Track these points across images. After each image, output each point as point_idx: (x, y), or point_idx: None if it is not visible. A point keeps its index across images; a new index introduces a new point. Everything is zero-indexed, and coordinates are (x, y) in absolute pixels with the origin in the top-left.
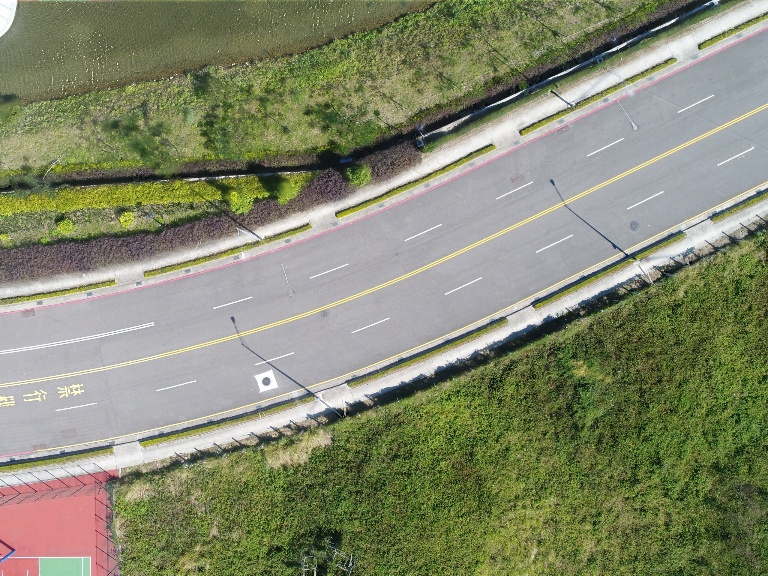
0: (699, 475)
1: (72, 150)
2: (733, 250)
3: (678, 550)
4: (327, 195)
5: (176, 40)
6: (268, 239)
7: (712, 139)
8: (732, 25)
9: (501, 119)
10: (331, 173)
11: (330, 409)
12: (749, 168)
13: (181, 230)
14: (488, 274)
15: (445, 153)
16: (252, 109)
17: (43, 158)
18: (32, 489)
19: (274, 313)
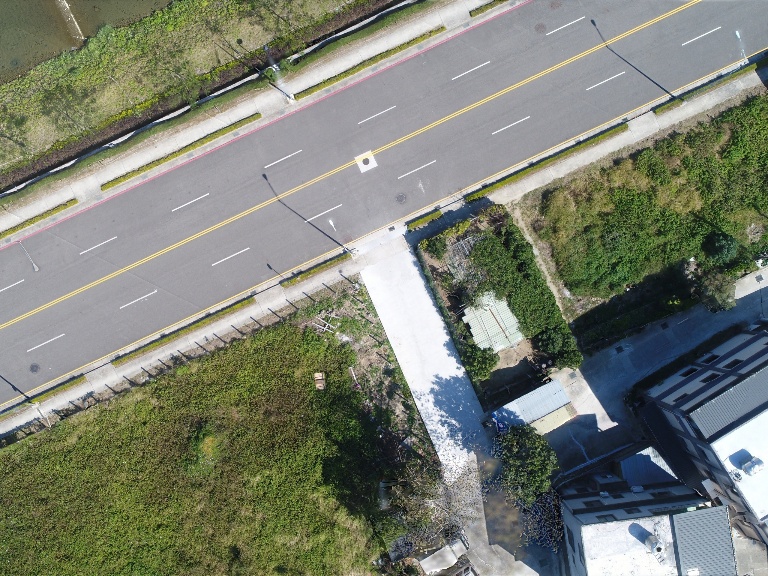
0: None
1: None
2: (125, 397)
3: None
4: None
5: None
6: None
7: (114, 281)
8: (136, 166)
9: None
10: None
11: None
12: (152, 311)
13: None
14: None
15: None
16: None
17: None
18: None
19: None
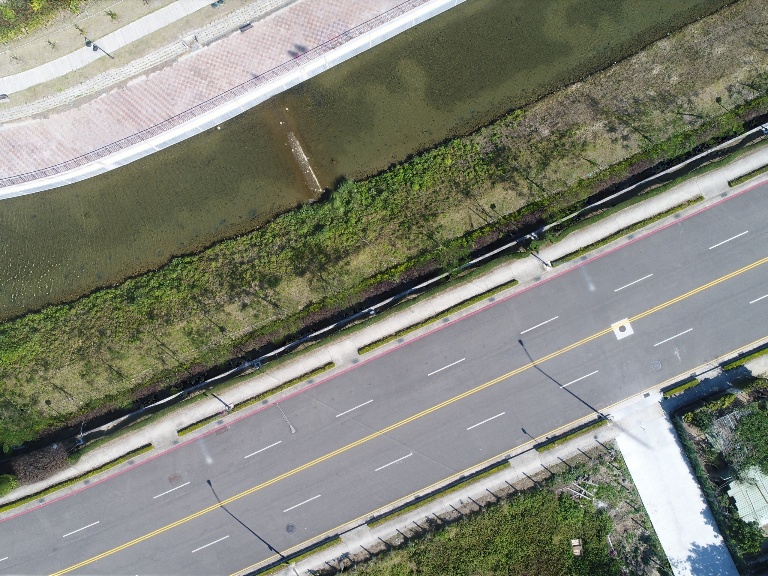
0: None
1: None
2: (384, 560)
3: None
4: None
5: None
6: None
7: (370, 444)
8: (393, 330)
9: (160, 419)
10: None
11: None
12: (407, 474)
13: None
14: (144, 572)
15: (104, 451)
16: None
17: None
18: None
19: None
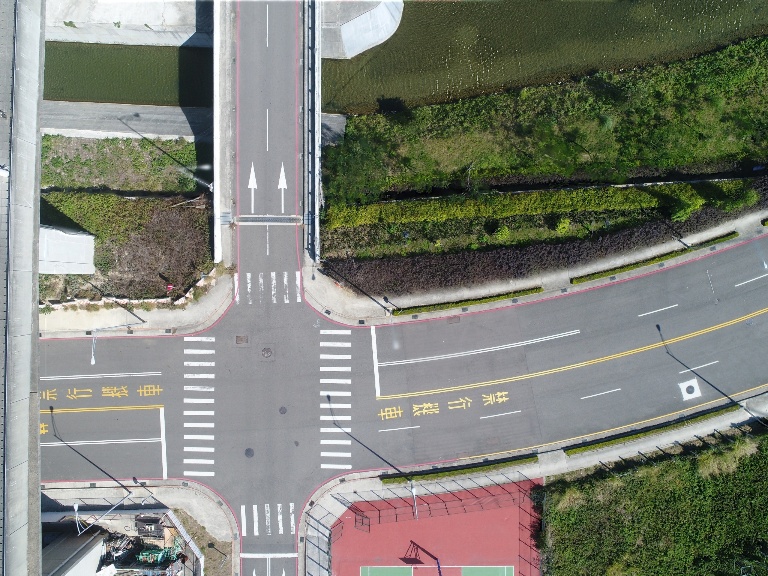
0: None
1: (486, 155)
2: None
3: None
4: (765, 203)
5: (562, 45)
6: (696, 247)
7: None
8: None
9: None
10: (767, 181)
11: (754, 418)
12: None
13: (619, 237)
14: None
15: None
16: (668, 115)
17: (455, 163)
18: (456, 497)
19: (699, 321)
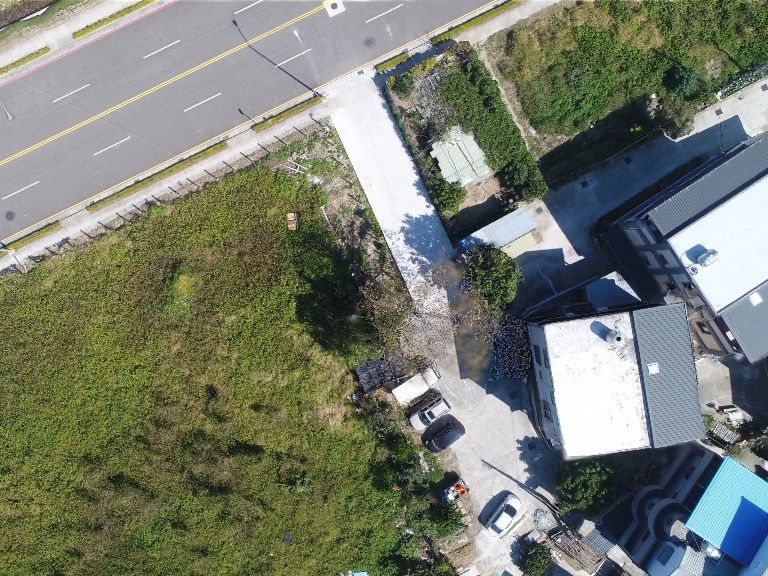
0: (69, 466)
1: None
2: (100, 240)
3: (50, 541)
4: None
5: None
6: None
7: (88, 129)
8: (107, 14)
9: None
10: None
11: None
12: (126, 158)
13: None
14: None
15: None
16: None
17: None
18: None
19: None
